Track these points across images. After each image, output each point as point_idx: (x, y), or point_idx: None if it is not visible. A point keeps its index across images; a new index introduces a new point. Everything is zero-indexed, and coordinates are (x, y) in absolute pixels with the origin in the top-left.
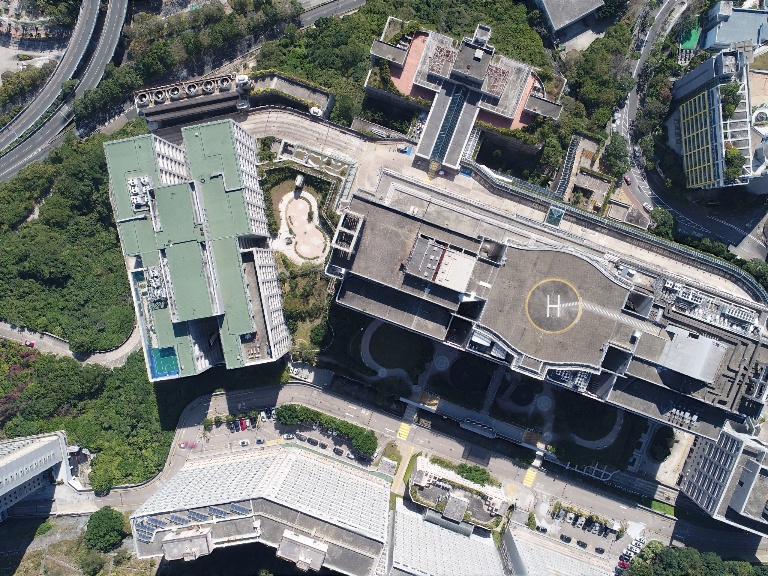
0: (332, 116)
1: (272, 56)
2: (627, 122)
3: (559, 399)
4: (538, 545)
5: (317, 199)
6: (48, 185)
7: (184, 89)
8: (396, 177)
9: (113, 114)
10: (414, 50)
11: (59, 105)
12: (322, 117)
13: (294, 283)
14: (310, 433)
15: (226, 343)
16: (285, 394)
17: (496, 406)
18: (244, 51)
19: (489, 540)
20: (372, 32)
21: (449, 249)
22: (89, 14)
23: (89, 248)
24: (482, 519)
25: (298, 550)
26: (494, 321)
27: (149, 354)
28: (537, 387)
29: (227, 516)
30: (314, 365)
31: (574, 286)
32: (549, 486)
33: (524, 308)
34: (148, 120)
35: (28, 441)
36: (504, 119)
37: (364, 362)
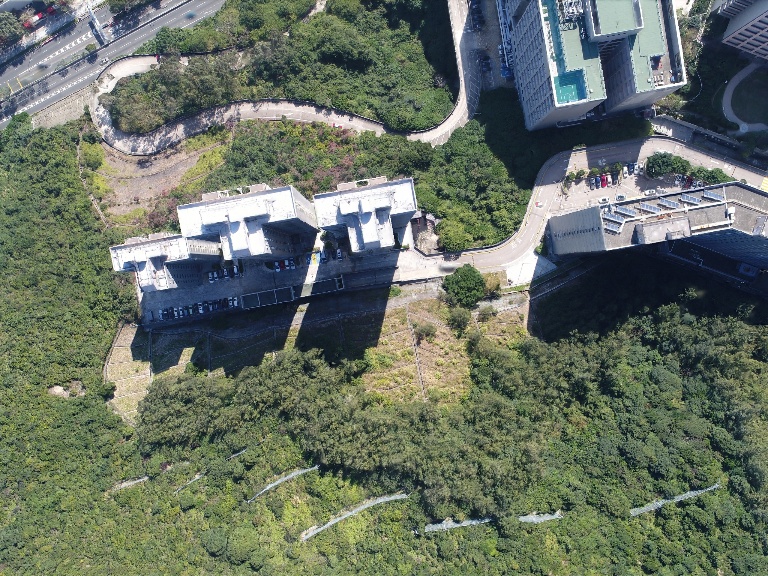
0: None
1: None
2: None
3: None
4: None
5: None
6: None
7: None
8: None
9: None
10: None
11: None
12: None
13: None
14: (671, 189)
15: (636, 65)
16: (647, 149)
17: None
18: None
19: None
20: None
21: None
22: None
23: (380, 41)
24: None
25: None
26: None
27: None
28: None
29: (699, 204)
30: (678, 118)
31: None
32: None
33: None
34: None
35: None
36: None
37: (726, 117)
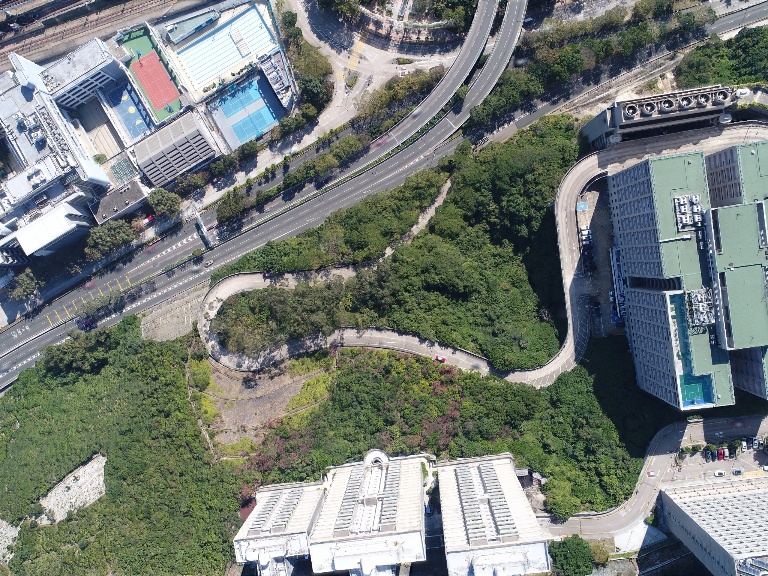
0: None
1: (703, 67)
2: None
3: None
4: None
5: None
6: (437, 194)
7: (677, 102)
8: None
9: (502, 122)
10: None
11: (447, 111)
12: None
13: None
14: None
15: None
16: (767, 424)
17: None
18: (644, 60)
19: None
20: None
21: None
22: (484, 18)
23: (482, 260)
24: None
25: None
26: None
27: None
28: None
29: None
30: None
31: None
32: None
33: None
34: (614, 132)
35: (490, 464)
36: None
37: None
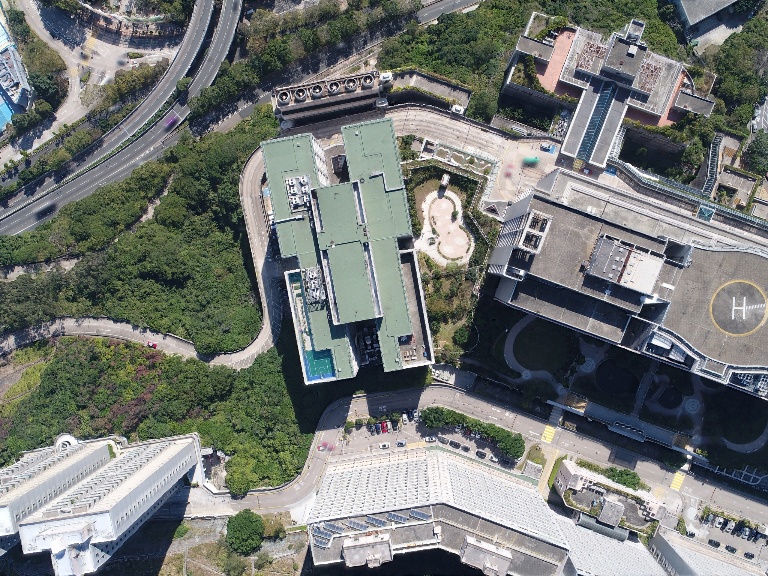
0: (468, 114)
1: (397, 53)
2: (767, 119)
3: (711, 402)
4: (693, 550)
5: (461, 198)
6: (163, 184)
7: (326, 87)
8: (573, 176)
9: (227, 112)
10: (559, 46)
11: (172, 103)
12: (462, 115)
13: (439, 284)
14: (452, 436)
15: (384, 345)
16: (427, 396)
17: (646, 409)
18: (360, 48)
19: (640, 545)
20: (500, 28)
21: (635, 250)
22: (203, 11)
23: (205, 248)
24: (636, 524)
25: (483, 557)
26: (677, 323)
27: (304, 356)
28: (688, 390)
29: (406, 522)
30: (457, 367)
31: (760, 288)
32: (697, 490)
33: (708, 310)
34: (283, 119)
35: (166, 443)
36: (651, 116)
37: (508, 364)
